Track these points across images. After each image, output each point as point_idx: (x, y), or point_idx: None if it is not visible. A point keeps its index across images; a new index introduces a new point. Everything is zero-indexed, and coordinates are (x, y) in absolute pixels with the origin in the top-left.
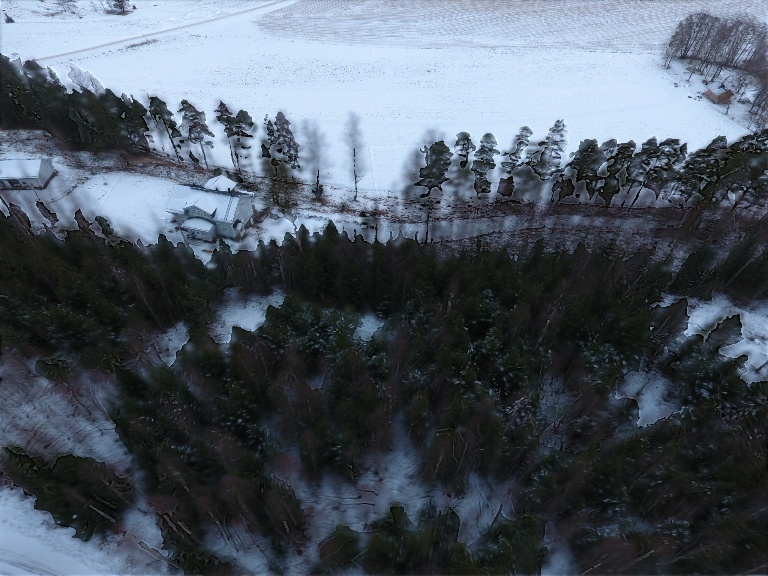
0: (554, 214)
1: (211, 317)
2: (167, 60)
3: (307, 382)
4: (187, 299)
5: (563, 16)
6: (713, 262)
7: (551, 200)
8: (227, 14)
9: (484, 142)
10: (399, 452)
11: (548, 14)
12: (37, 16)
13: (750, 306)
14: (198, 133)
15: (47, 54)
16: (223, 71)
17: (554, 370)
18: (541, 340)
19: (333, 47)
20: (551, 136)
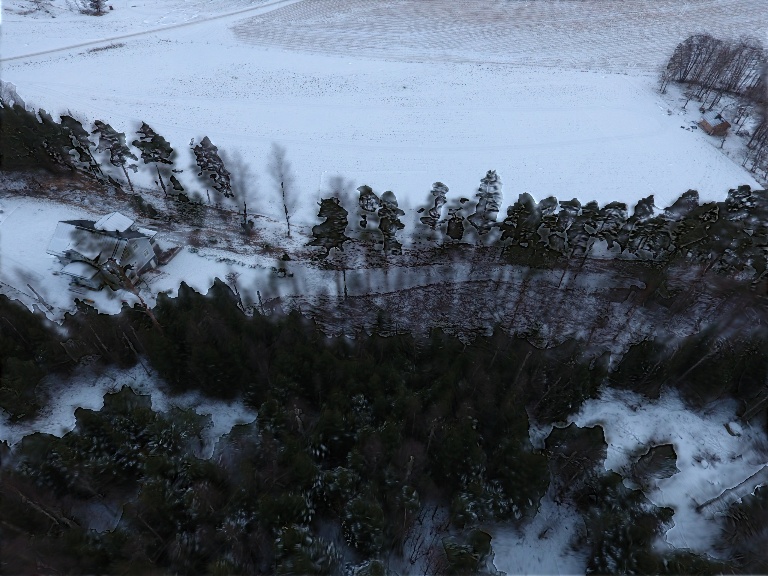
0: (506, 264)
1: (47, 398)
2: (129, 66)
3: (131, 499)
4: None
5: (558, 31)
6: (658, 358)
7: (504, 247)
8: (203, 18)
9: (383, 201)
10: None
11: (542, 29)
12: (9, 14)
13: (705, 408)
14: (119, 156)
15: (3, 56)
16: (186, 80)
17: (438, 499)
18: (410, 473)
19: (308, 57)
20: (484, 187)
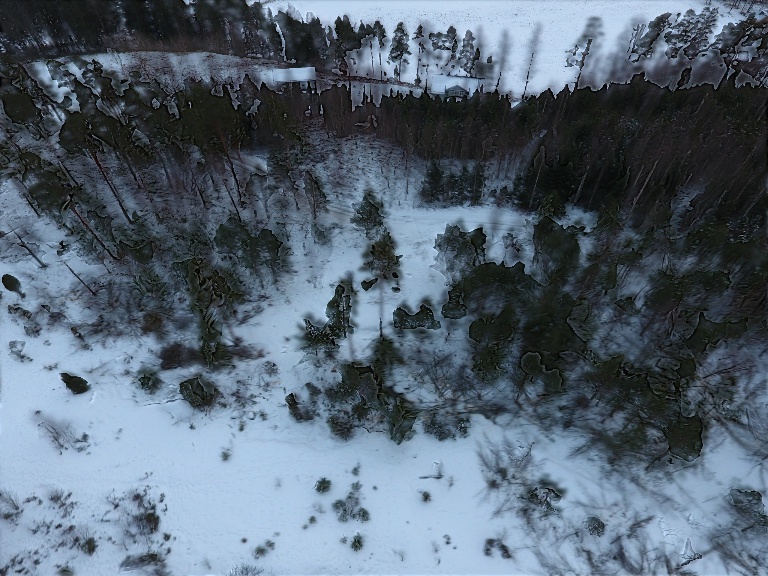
0: None
1: None
2: None
3: None
4: (534, 113)
5: None
6: None
7: None
8: None
9: (687, 16)
10: (688, 185)
11: None
12: None
13: None
14: (401, 52)
15: None
16: None
17: None
18: (759, 119)
19: (425, 0)
20: (706, 22)
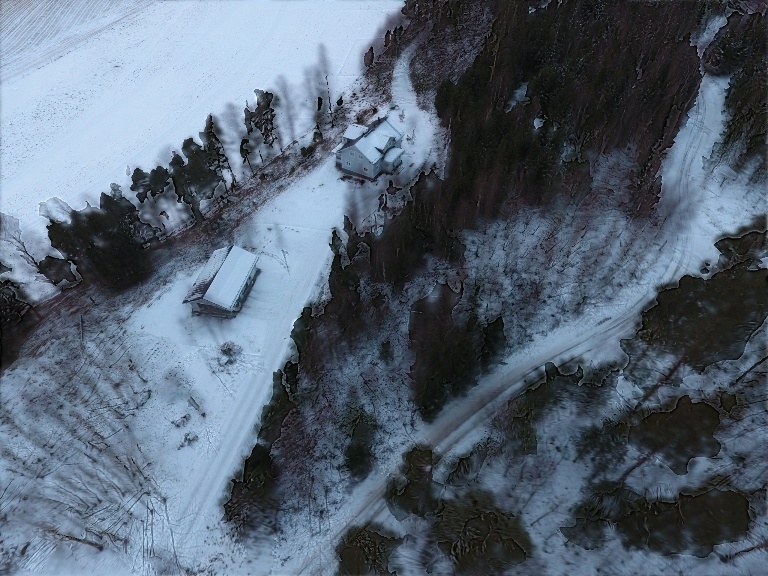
0: None
1: None
2: None
3: None
4: None
5: None
6: None
7: None
8: None
9: None
10: None
11: None
12: None
13: None
14: (217, 160)
15: None
16: None
17: None
18: None
19: None
20: None
